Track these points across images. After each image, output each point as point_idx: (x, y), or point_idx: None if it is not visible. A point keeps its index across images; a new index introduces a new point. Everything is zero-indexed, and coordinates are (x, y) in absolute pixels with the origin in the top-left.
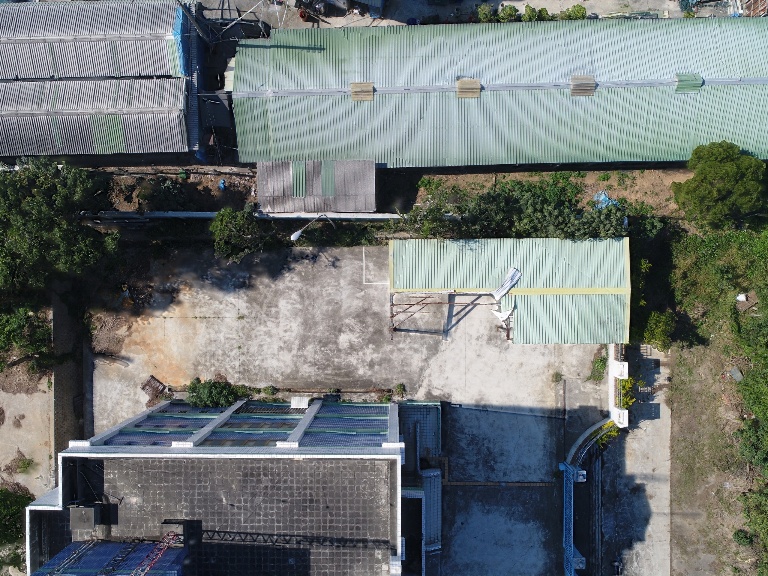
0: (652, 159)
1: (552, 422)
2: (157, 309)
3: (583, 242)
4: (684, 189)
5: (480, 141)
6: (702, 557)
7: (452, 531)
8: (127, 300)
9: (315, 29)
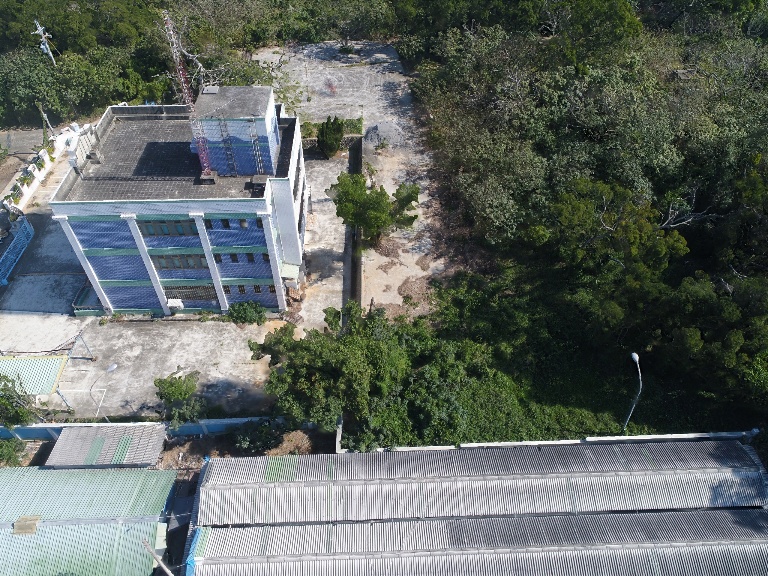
0: None
1: None
2: None
3: None
4: None
5: None
6: None
7: None
8: None
9: None
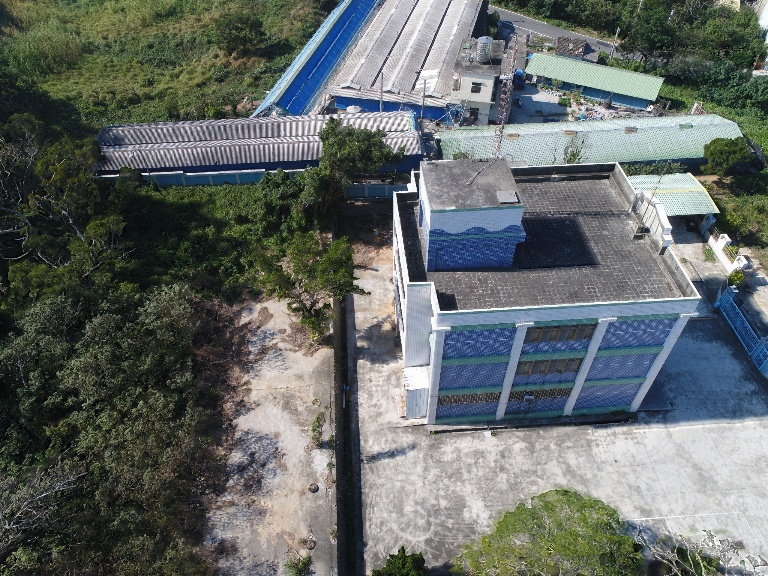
0: (683, 158)
1: (694, 284)
2: None
3: (665, 175)
4: (708, 152)
5: (583, 154)
6: None
7: None
8: (376, 237)
9: (476, 126)
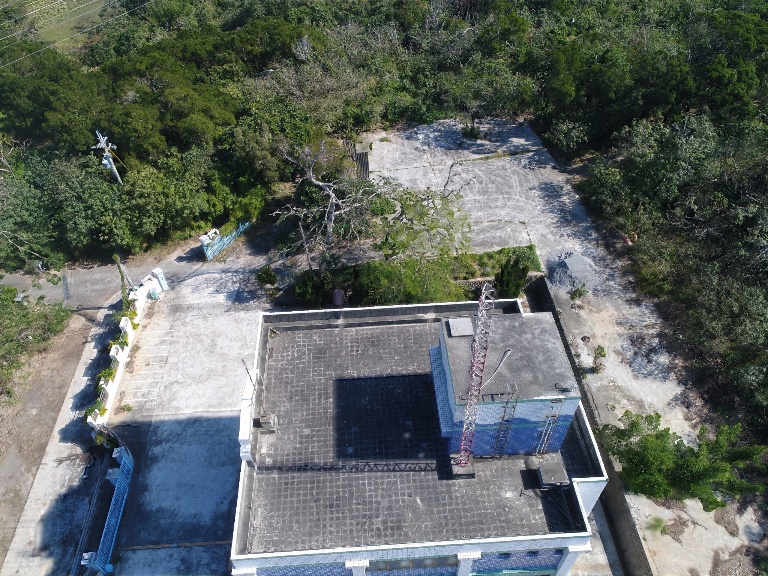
0: None
1: None
2: None
3: None
4: None
5: None
6: (2, 489)
7: (233, 495)
8: None
9: None
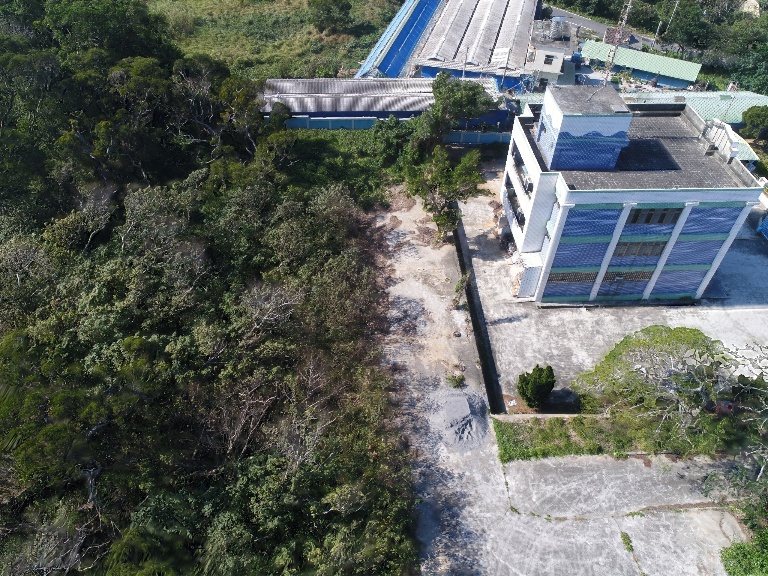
0: None
1: None
2: (489, 178)
3: None
4: (747, 116)
5: None
6: None
7: None
8: None
9: None
